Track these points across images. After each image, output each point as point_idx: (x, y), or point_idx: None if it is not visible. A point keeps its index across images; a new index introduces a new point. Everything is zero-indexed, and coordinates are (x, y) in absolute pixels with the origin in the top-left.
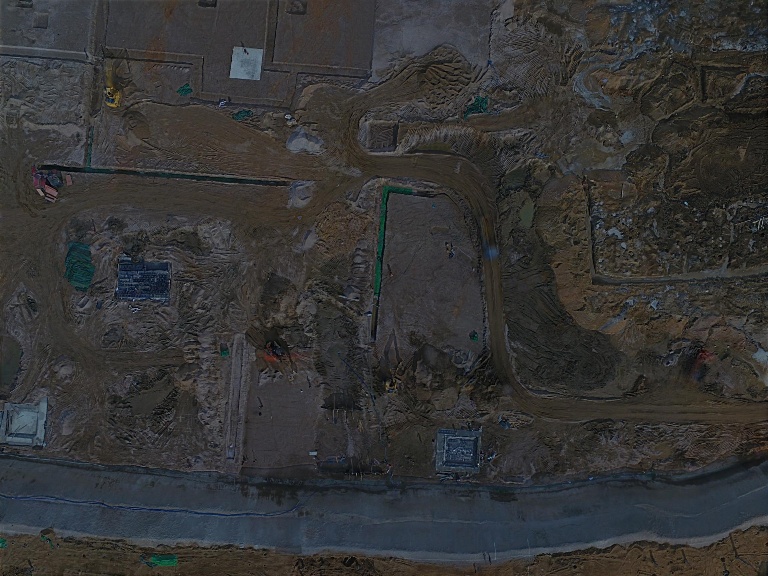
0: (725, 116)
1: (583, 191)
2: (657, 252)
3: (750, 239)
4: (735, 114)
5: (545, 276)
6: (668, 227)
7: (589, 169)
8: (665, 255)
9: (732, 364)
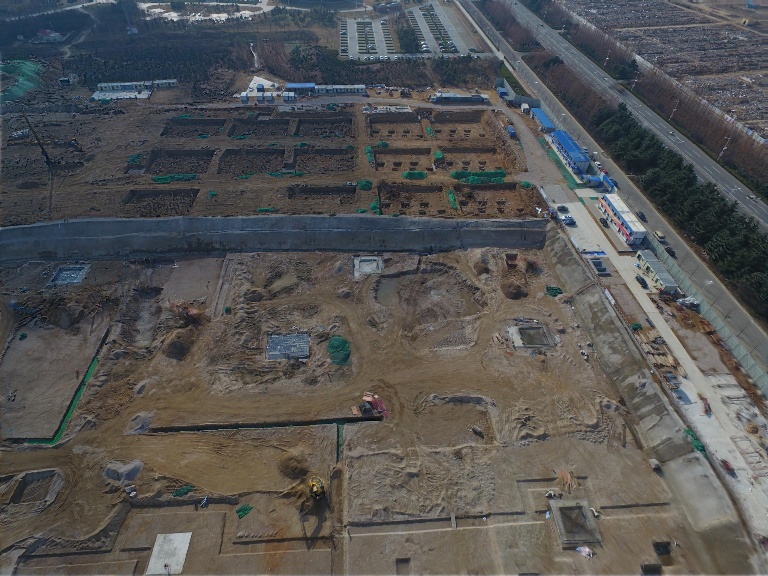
0: None
1: None
2: None
3: None
4: None
5: None
6: None
7: None
8: None
9: None
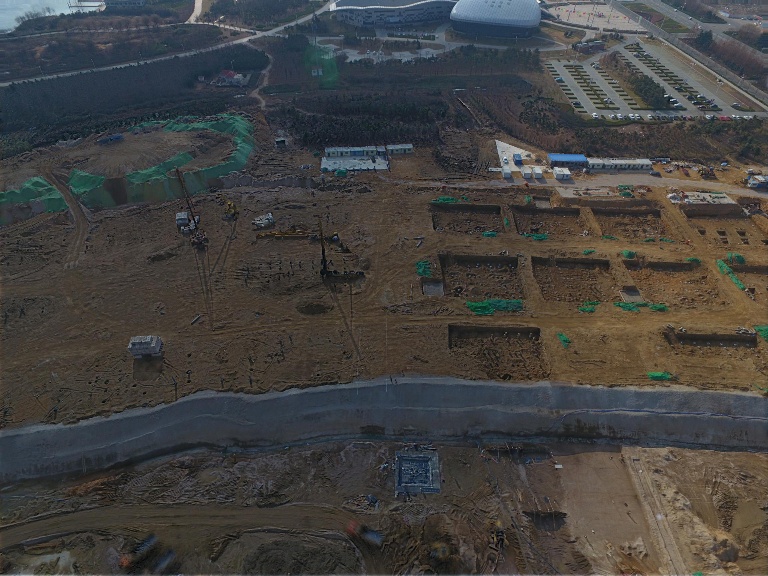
0: None
1: None
2: None
3: None
4: None
5: None
6: None
7: None
8: None
9: None
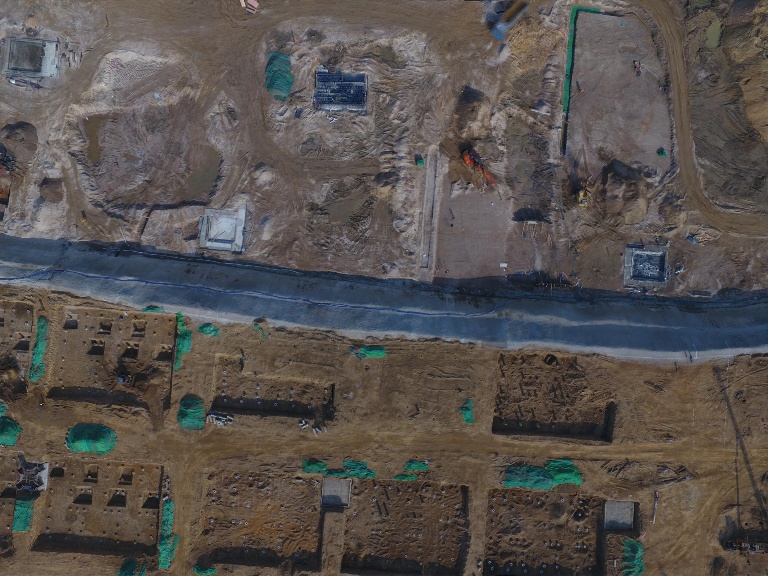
0: None
1: None
2: None
3: None
4: None
5: (732, 95)
6: None
7: None
8: None
9: None
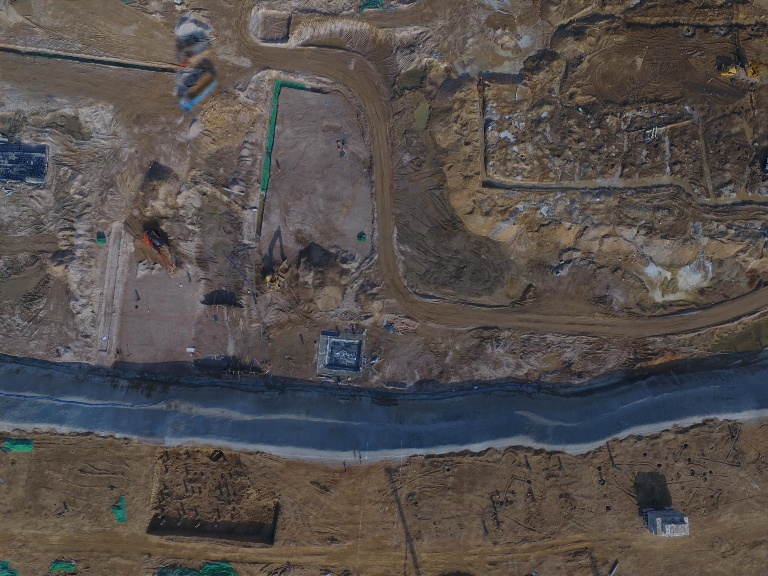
0: (623, 24)
1: (476, 91)
2: (549, 157)
3: (643, 149)
4: (634, 23)
5: (437, 179)
6: (561, 132)
7: (486, 72)
8: (556, 160)
9: (623, 277)
